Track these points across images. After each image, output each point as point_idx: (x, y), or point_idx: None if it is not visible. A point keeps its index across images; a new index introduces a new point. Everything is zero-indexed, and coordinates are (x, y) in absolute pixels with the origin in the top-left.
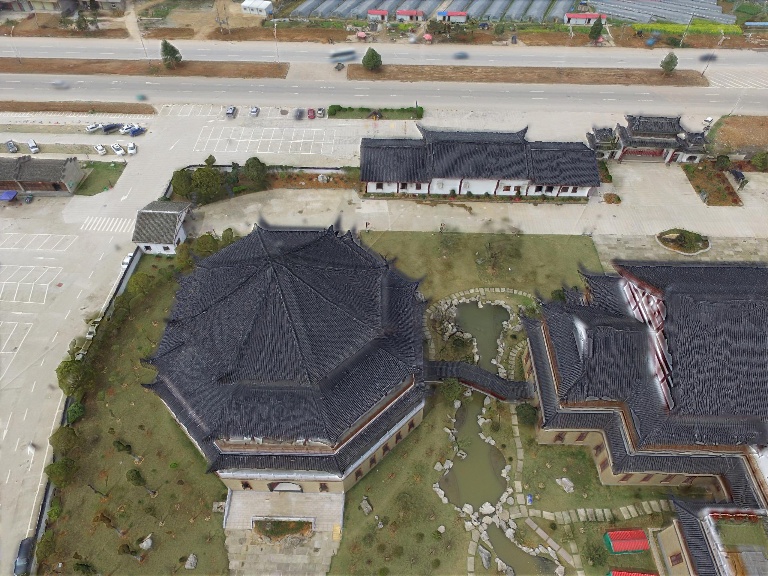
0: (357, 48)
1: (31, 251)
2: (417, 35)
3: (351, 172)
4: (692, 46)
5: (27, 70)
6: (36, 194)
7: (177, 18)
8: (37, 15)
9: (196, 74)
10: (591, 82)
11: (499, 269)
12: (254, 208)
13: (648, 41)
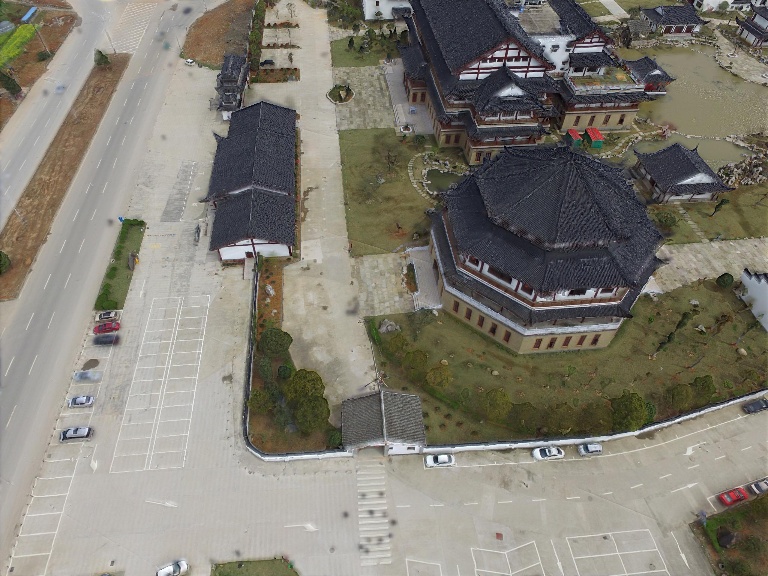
0: None
1: None
2: None
3: None
4: (54, 50)
5: None
6: None
7: None
8: None
9: None
10: (103, 108)
11: None
12: (322, 353)
13: (38, 66)
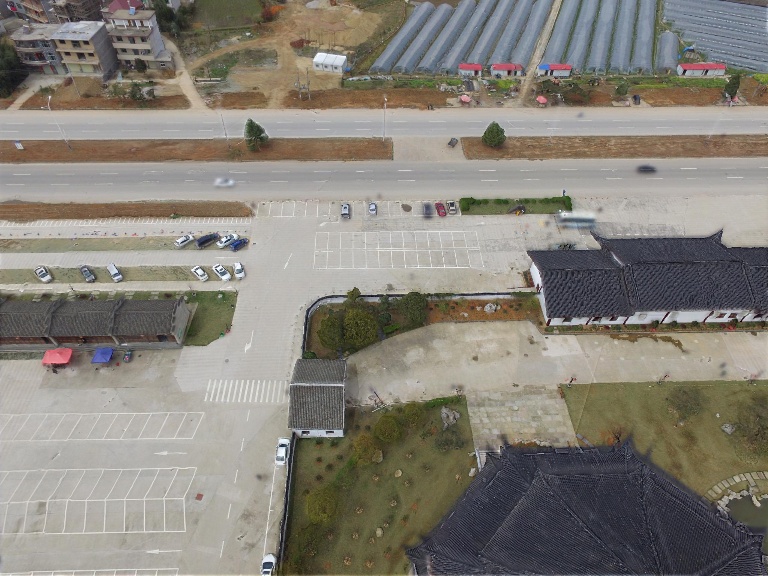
0: (463, 115)
1: (149, 442)
2: (523, 95)
3: (523, 297)
4: None
5: (80, 158)
6: (134, 347)
7: (240, 79)
8: (75, 80)
9: (286, 157)
10: (745, 154)
11: (758, 442)
12: (416, 355)
13: None
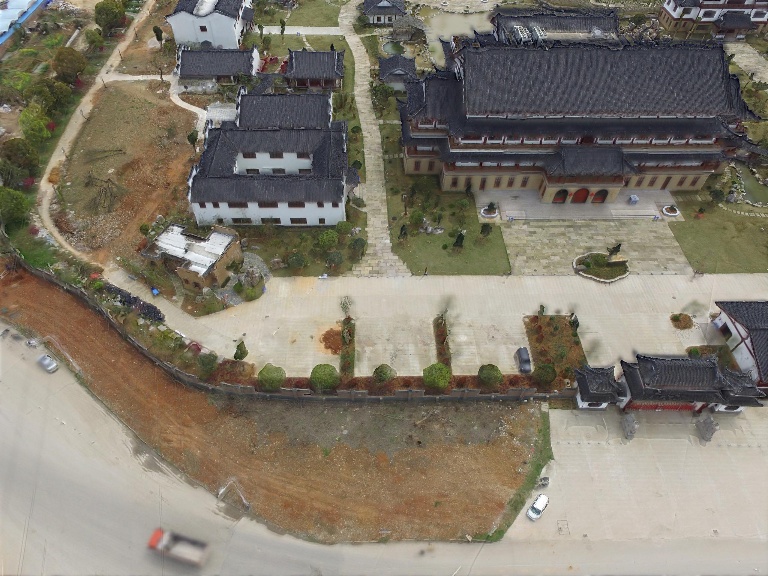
0: None
1: None
2: None
3: None
4: None
5: None
6: None
7: None
8: None
9: None
10: None
11: None
12: None
13: None
